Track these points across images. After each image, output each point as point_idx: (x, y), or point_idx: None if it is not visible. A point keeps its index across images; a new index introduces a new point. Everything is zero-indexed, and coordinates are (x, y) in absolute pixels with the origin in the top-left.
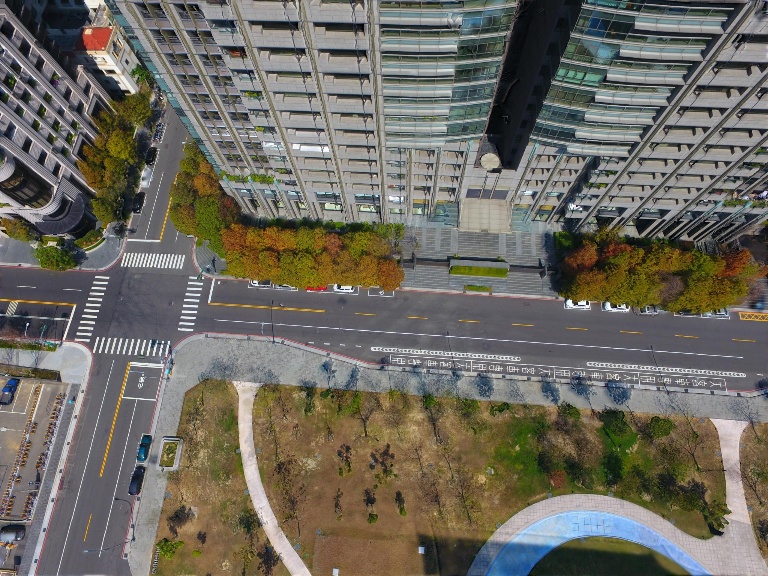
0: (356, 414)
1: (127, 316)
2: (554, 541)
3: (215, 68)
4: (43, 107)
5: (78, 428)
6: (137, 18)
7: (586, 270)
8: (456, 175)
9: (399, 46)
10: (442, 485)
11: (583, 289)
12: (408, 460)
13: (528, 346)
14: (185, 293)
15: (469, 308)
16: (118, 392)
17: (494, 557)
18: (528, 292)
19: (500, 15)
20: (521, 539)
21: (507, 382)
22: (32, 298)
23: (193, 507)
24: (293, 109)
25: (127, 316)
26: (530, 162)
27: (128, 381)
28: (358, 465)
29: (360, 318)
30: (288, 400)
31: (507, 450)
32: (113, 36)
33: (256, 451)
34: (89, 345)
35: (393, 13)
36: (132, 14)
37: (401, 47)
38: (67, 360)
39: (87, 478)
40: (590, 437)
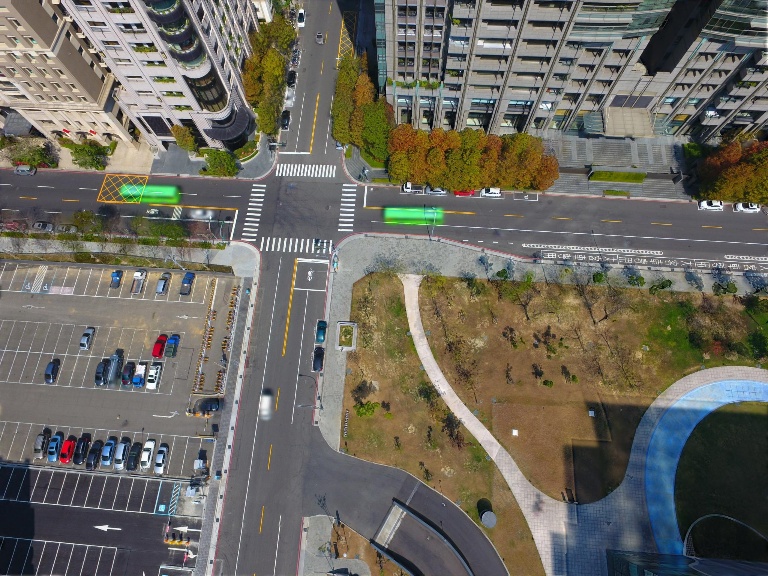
0: (516, 301)
1: (288, 219)
2: (711, 405)
3: None
4: (224, 15)
5: (256, 315)
6: None
7: (733, 164)
8: (611, 79)
9: None
10: (603, 360)
11: (729, 183)
12: (569, 339)
13: (669, 242)
14: (341, 198)
15: (610, 210)
16: (289, 284)
17: (658, 419)
18: (663, 196)
19: None
20: (681, 404)
21: (653, 272)
22: (195, 204)
23: (374, 381)
24: None
25: (288, 219)
26: (690, 61)
27: (297, 275)
28: (523, 344)
29: (509, 219)
30: (451, 289)
31: (659, 330)
32: None
33: (426, 333)
34: (256, 244)
35: None
36: None
37: None
38: (237, 257)
39: (271, 358)
40: (735, 318)
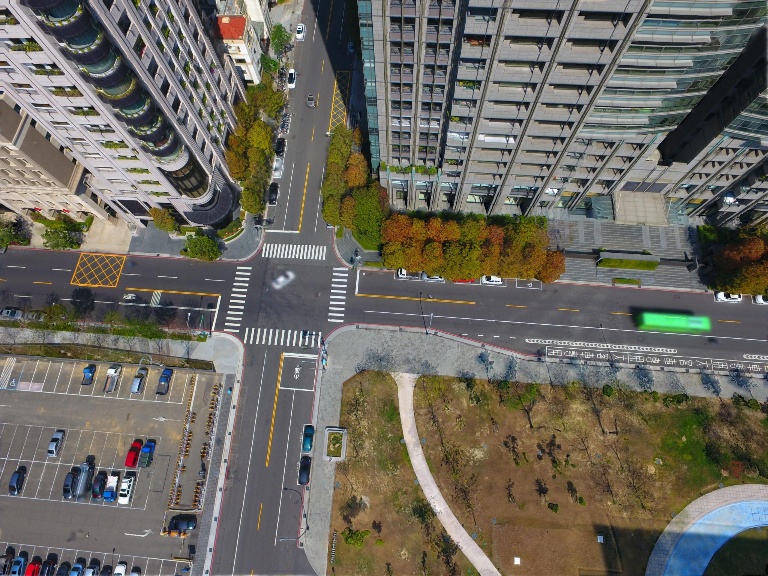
0: (518, 405)
1: (274, 307)
2: (730, 530)
3: (437, 57)
4: (205, 95)
5: (238, 418)
6: (386, 5)
7: (755, 263)
8: (623, 168)
9: (652, 36)
10: (612, 475)
11: (750, 282)
12: (575, 451)
13: (683, 338)
14: (331, 284)
15: (620, 301)
16: (275, 382)
17: (673, 546)
18: (677, 285)
19: (767, 6)
20: (697, 528)
21: (666, 374)
22: (175, 288)
23: (364, 497)
24: (504, 99)
25: (274, 307)
26: (709, 155)
27: (283, 372)
28: (526, 455)
29: (511, 310)
30: (448, 391)
31: (674, 441)
32: (247, 25)
33: (421, 441)
34: (239, 336)
35: (665, 3)
36: (384, 1)
37: (654, 37)
38: (219, 350)
39: (253, 468)
40: (755, 428)
